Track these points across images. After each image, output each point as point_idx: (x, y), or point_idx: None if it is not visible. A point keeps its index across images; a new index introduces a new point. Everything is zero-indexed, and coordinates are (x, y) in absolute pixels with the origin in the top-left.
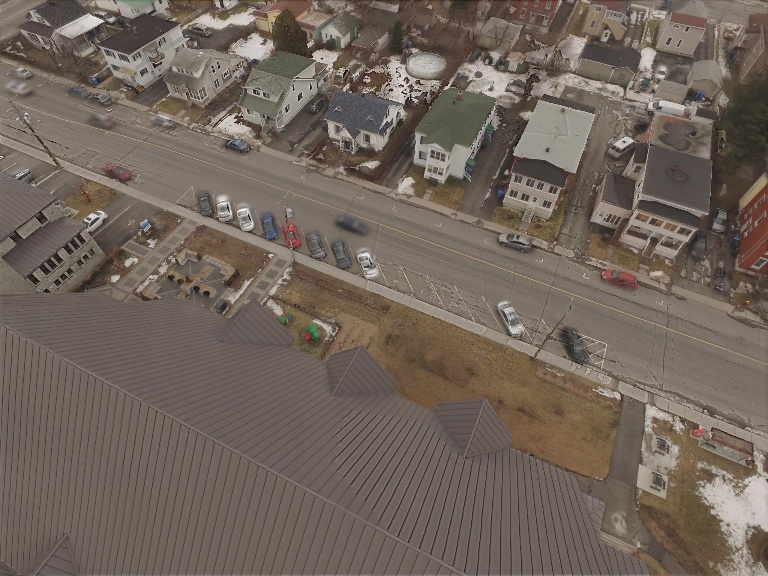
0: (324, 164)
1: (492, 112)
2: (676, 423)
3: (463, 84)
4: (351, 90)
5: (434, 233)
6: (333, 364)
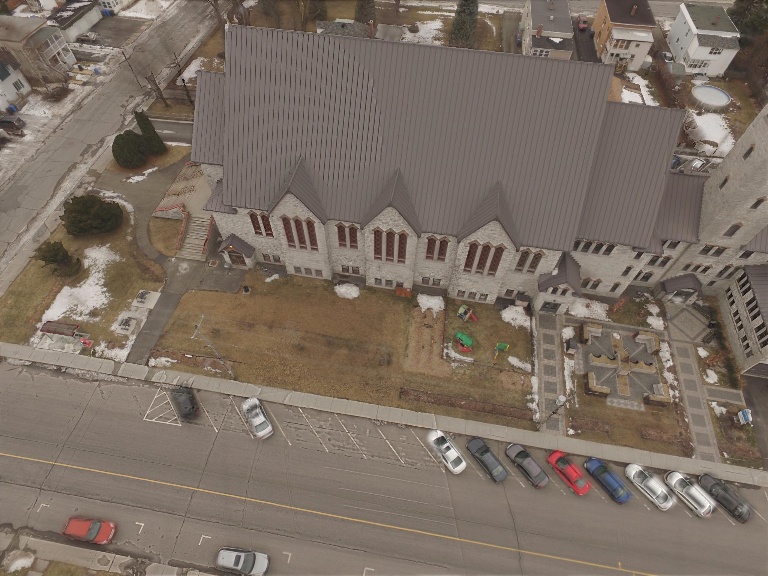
0: None
1: None
2: (102, 349)
3: None
4: None
5: (372, 547)
6: None
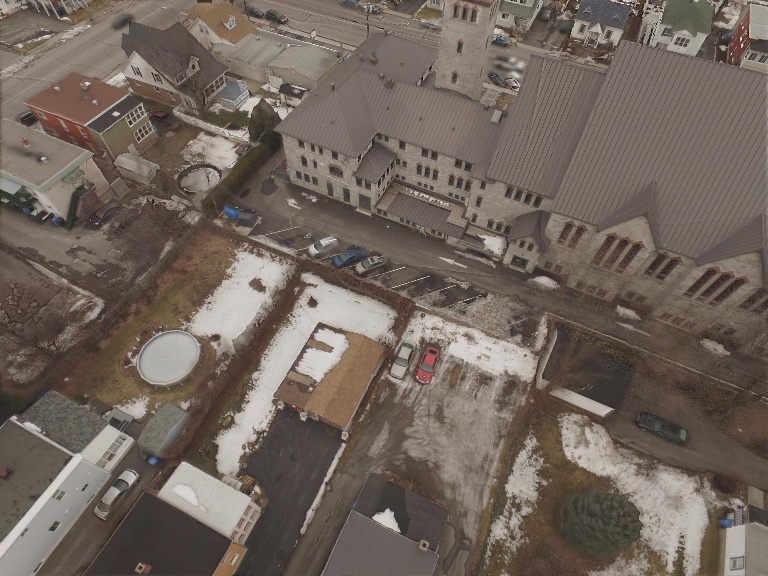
0: (574, 55)
1: None
2: None
3: (658, 2)
4: (568, 6)
5: None
6: None
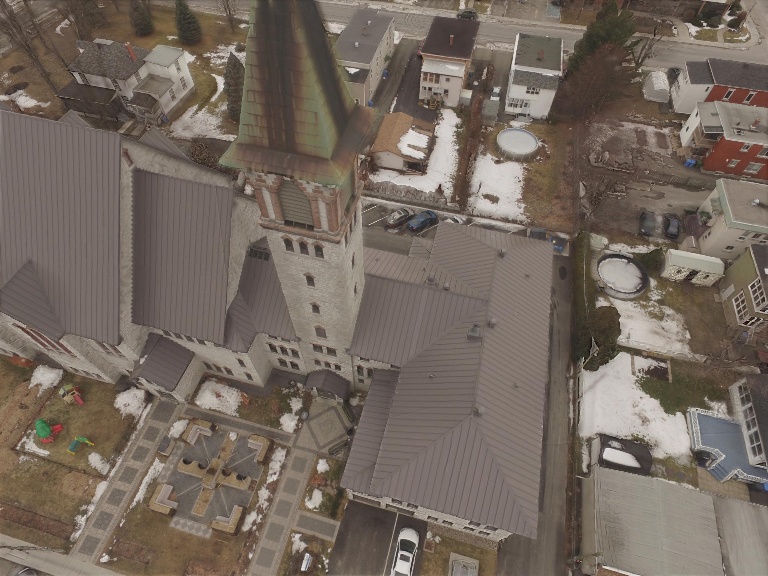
0: None
1: None
2: None
3: None
4: None
5: None
6: None
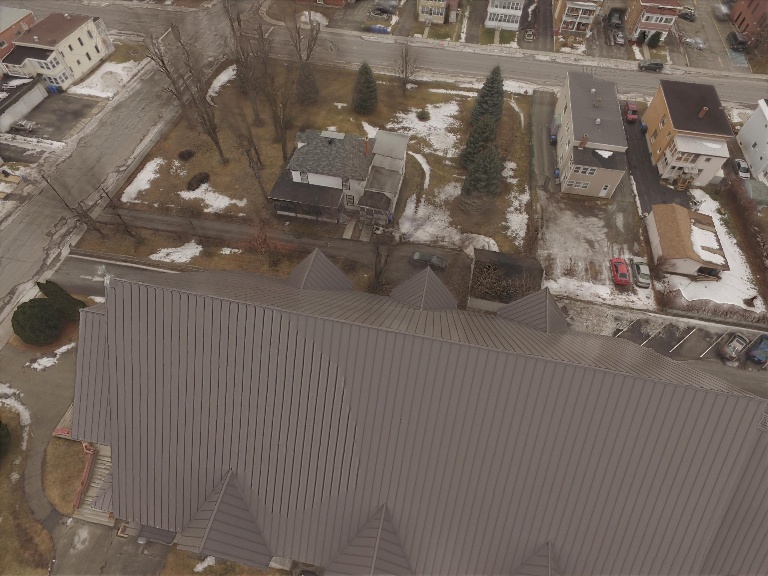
0: None
1: None
2: None
3: None
4: None
5: None
6: (406, 575)
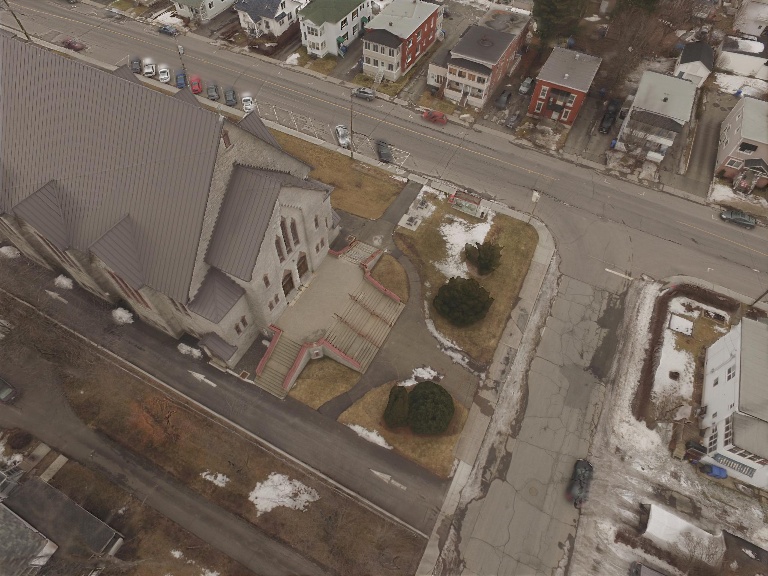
0: (233, 44)
1: (368, 8)
2: (440, 195)
3: None
4: None
5: (305, 88)
6: None
